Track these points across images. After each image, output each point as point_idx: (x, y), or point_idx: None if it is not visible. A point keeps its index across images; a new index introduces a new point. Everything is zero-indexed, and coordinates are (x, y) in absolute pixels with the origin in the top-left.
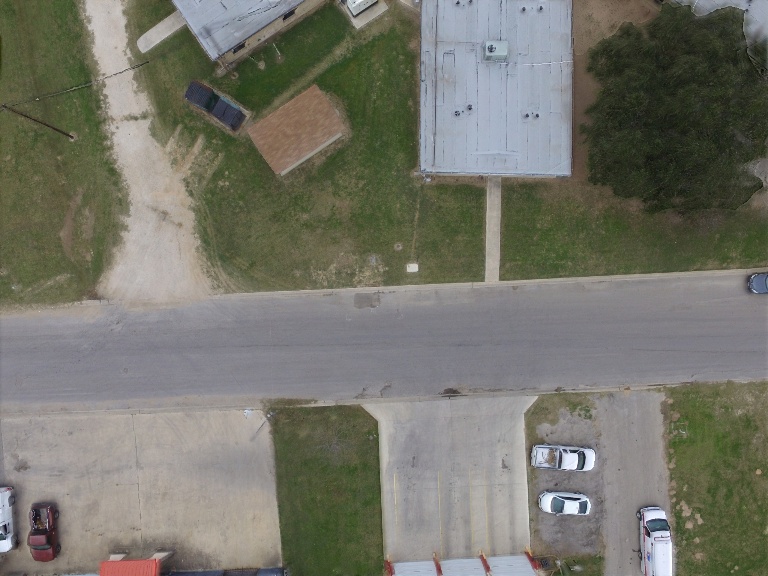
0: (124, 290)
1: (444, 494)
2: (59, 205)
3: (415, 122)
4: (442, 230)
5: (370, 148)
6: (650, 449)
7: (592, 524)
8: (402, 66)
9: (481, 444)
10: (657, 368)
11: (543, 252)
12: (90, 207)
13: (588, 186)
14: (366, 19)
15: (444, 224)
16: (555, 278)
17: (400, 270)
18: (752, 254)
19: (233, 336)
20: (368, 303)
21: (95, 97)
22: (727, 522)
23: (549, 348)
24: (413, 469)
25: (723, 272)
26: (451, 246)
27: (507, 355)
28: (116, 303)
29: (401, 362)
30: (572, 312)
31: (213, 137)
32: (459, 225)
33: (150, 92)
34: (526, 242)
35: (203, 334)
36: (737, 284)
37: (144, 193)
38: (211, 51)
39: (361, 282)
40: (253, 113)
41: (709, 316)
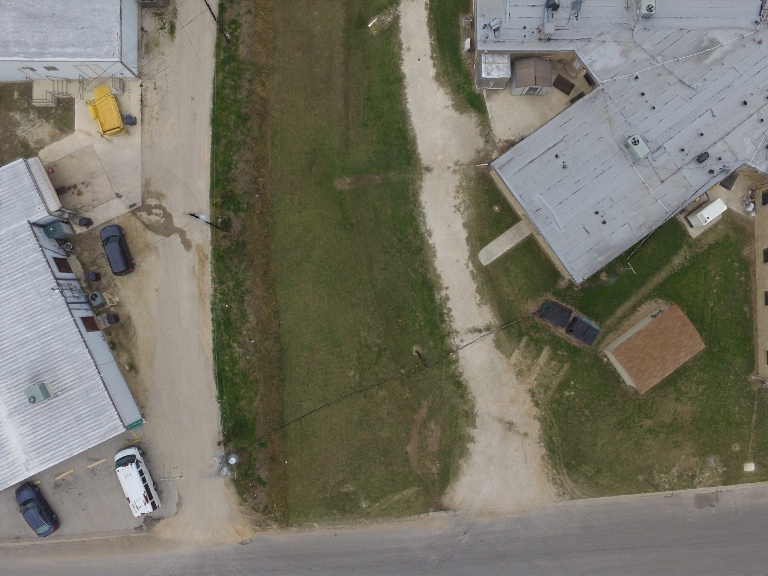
0: (471, 500)
1: None
2: (404, 419)
3: (751, 327)
4: None
5: (709, 354)
6: None
7: None
8: (737, 273)
9: None
10: None
11: None
12: (436, 420)
13: None
14: (702, 228)
15: None
16: None
17: (737, 470)
18: None
19: (579, 541)
20: (707, 502)
21: (439, 311)
22: None
23: None
24: None
25: None
26: None
27: None
28: (462, 513)
29: (739, 558)
30: None
31: (558, 348)
32: None
33: (493, 304)
34: None
35: (550, 541)
36: None
37: (489, 404)
38: (576, 276)
39: (700, 483)
40: (597, 324)
41: None
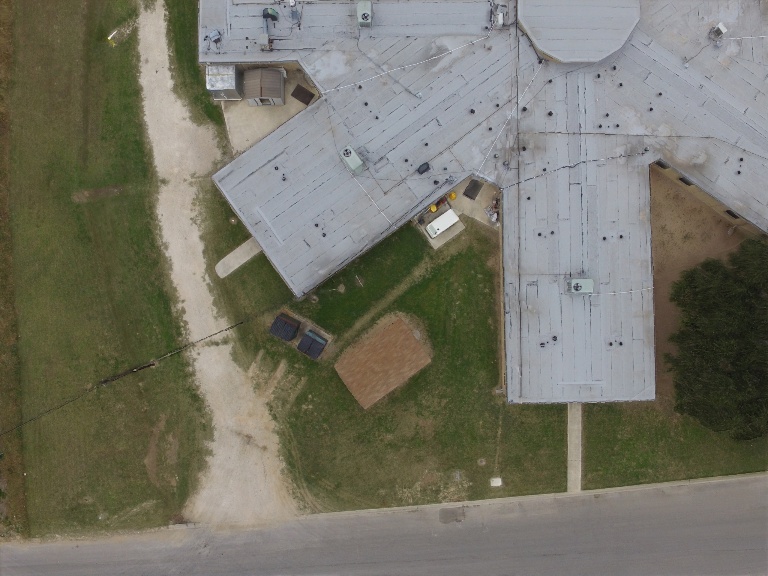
0: (210, 513)
1: None
2: (142, 432)
3: (495, 340)
4: (524, 445)
5: (451, 367)
6: None
7: None
8: (481, 285)
9: None
10: (736, 567)
11: (623, 461)
12: (174, 433)
13: (666, 396)
14: (443, 239)
15: (526, 439)
16: (635, 485)
17: (484, 485)
18: None
19: (321, 555)
20: (453, 518)
21: (175, 324)
22: None
23: (631, 554)
24: None
25: None
26: (534, 460)
27: (591, 562)
28: (203, 526)
29: (487, 574)
30: (653, 517)
31: (295, 362)
32: (541, 439)
33: (230, 317)
34: (607, 452)
35: (291, 554)
36: None
37: (227, 418)
38: (296, 289)
39: (446, 497)
40: (334, 337)
41: None
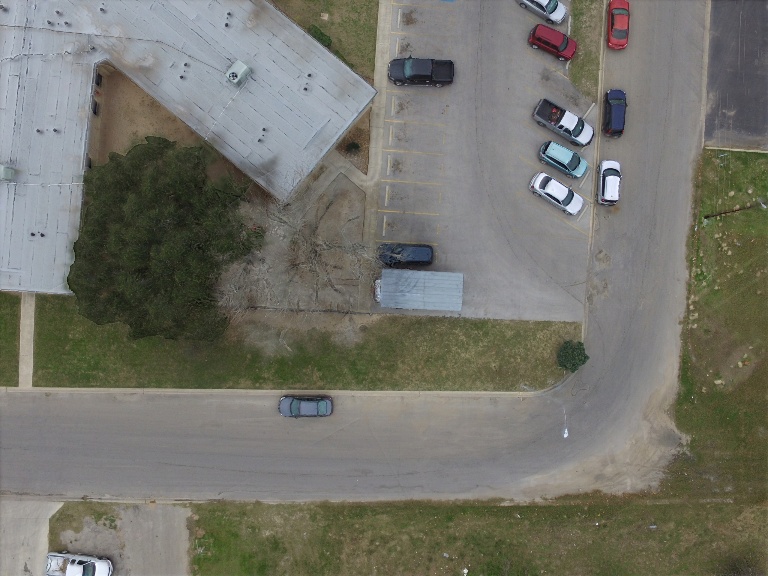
0: None
1: None
2: None
3: None
4: None
5: None
6: (174, 563)
7: None
8: None
9: (5, 546)
10: (184, 483)
11: (75, 362)
12: None
13: None
14: None
15: None
16: (87, 387)
17: None
18: (285, 376)
19: None
20: None
21: None
22: None
23: (77, 456)
24: None
25: (257, 392)
26: None
27: (35, 460)
28: None
29: None
30: (101, 422)
31: None
32: None
33: None
34: (58, 351)
35: None
36: (271, 404)
37: None
38: None
39: None
40: None
41: (239, 435)
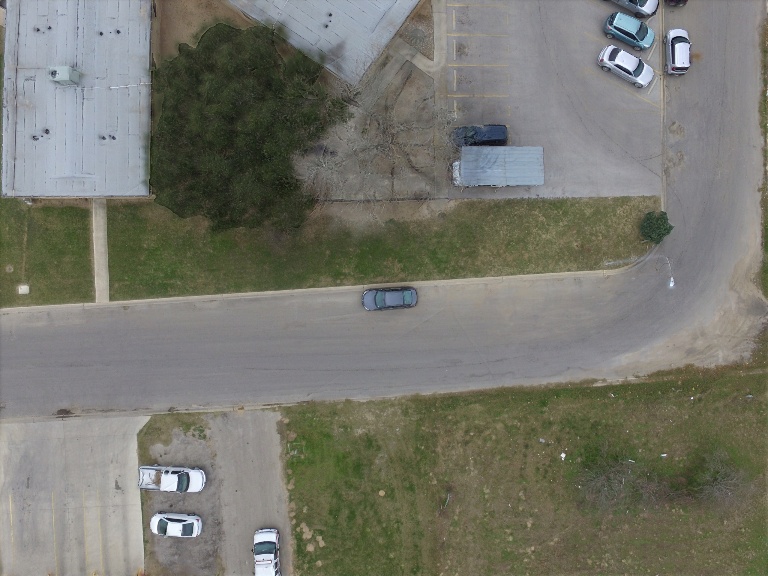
0: None
1: (59, 515)
2: None
3: None
4: (50, 252)
5: None
6: (267, 470)
7: (209, 546)
8: None
9: (94, 465)
10: (271, 387)
11: (151, 272)
12: None
13: None
14: None
15: (52, 246)
16: (165, 298)
17: (12, 292)
18: (366, 270)
19: None
20: None
21: None
22: (350, 545)
23: (160, 368)
24: (28, 490)
25: (338, 289)
26: (59, 268)
27: (118, 375)
28: None
29: (15, 383)
30: (183, 332)
31: None
32: (66, 247)
33: None
34: (133, 262)
35: None
36: (353, 301)
37: None
38: None
39: None
40: None
41: (324, 334)
